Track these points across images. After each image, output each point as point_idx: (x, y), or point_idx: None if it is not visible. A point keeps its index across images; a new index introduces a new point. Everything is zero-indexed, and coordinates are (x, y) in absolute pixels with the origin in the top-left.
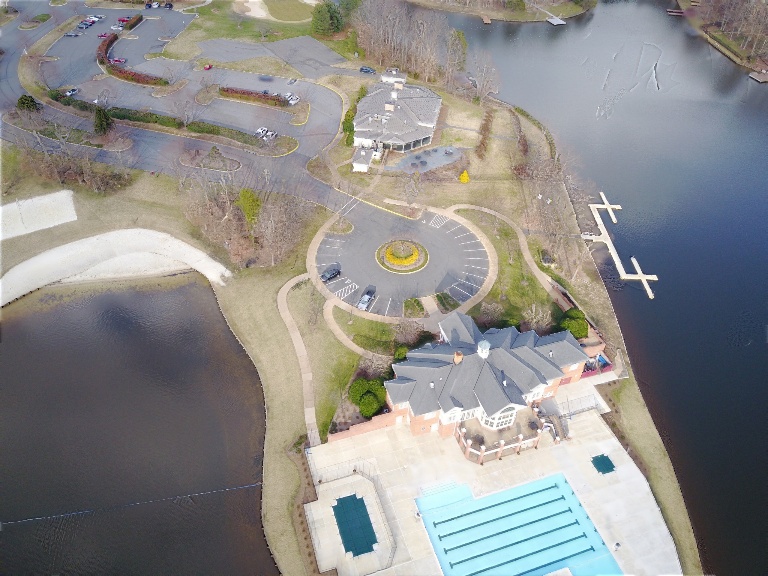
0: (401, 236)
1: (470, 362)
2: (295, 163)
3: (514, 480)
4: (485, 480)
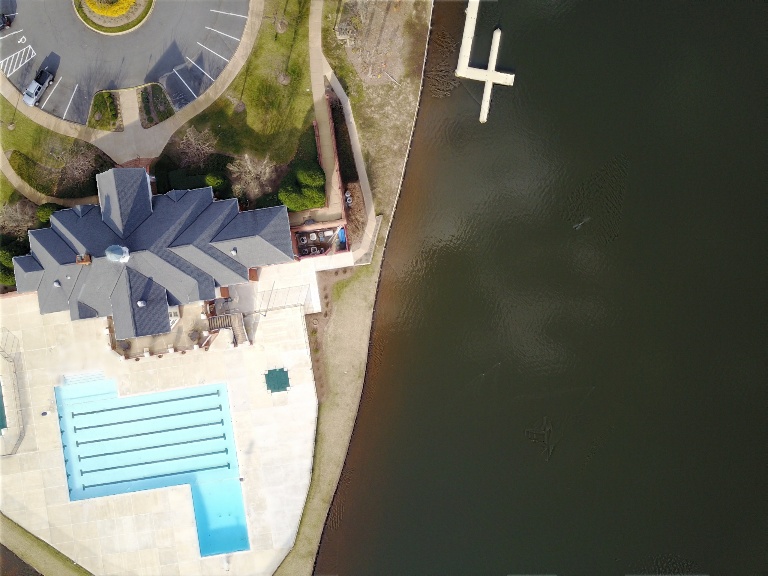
0: None
1: (102, 266)
2: None
3: (168, 383)
4: (136, 378)
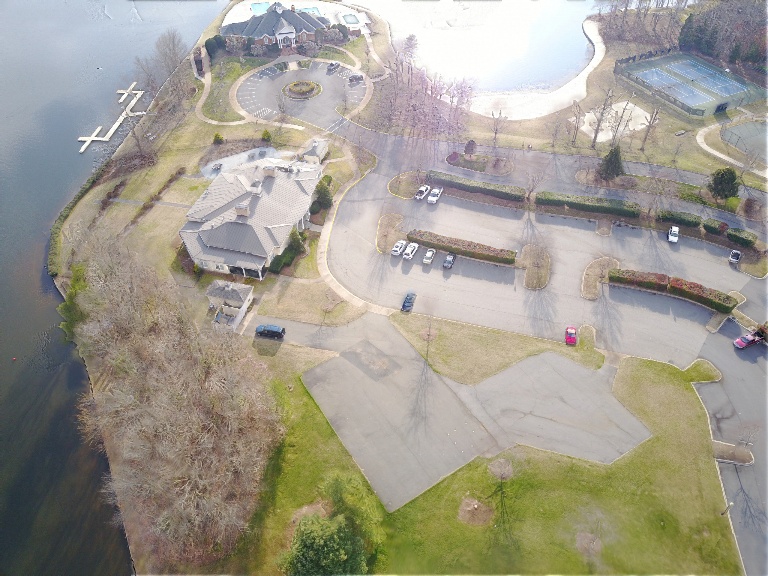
0: (298, 102)
1: None
2: (389, 165)
3: None
4: None
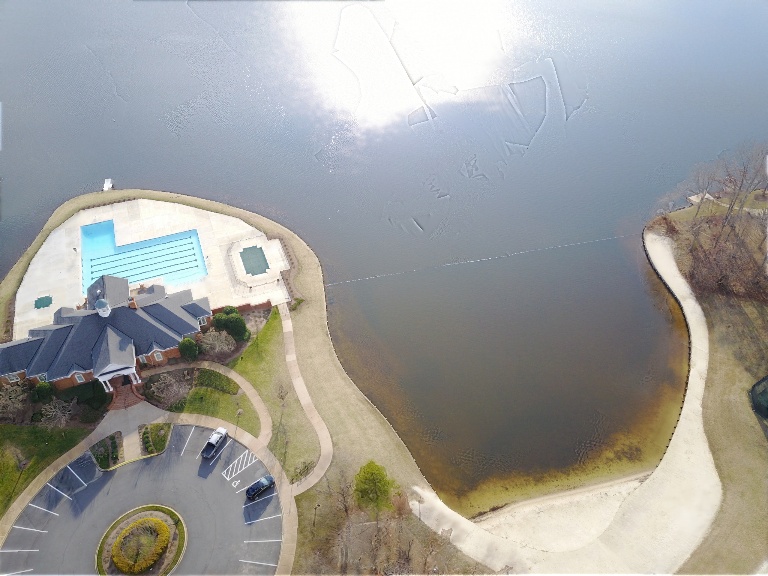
0: None
1: None
2: None
3: None
4: None
